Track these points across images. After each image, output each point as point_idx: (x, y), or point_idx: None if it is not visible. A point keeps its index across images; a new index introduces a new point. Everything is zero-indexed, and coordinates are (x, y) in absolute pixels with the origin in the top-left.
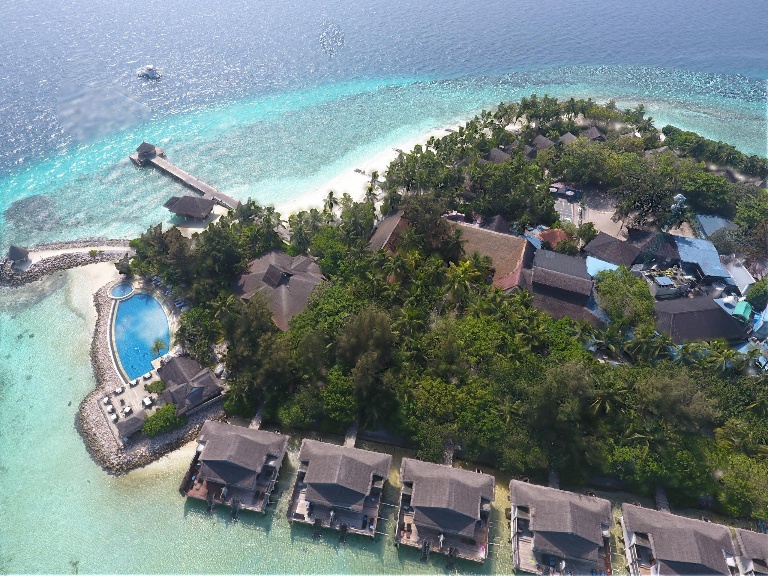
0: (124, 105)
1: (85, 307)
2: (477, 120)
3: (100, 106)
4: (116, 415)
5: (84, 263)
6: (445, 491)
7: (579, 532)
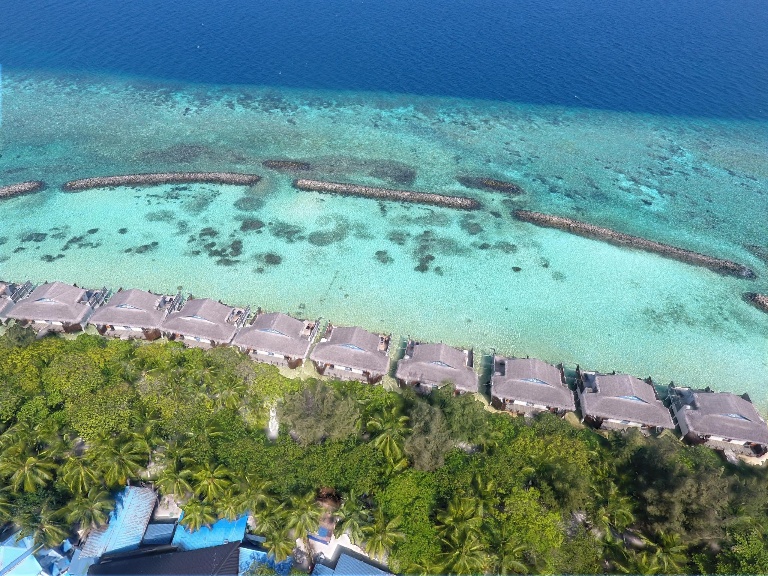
0: None
1: None
2: None
3: None
4: None
5: None
6: (539, 369)
7: (436, 345)
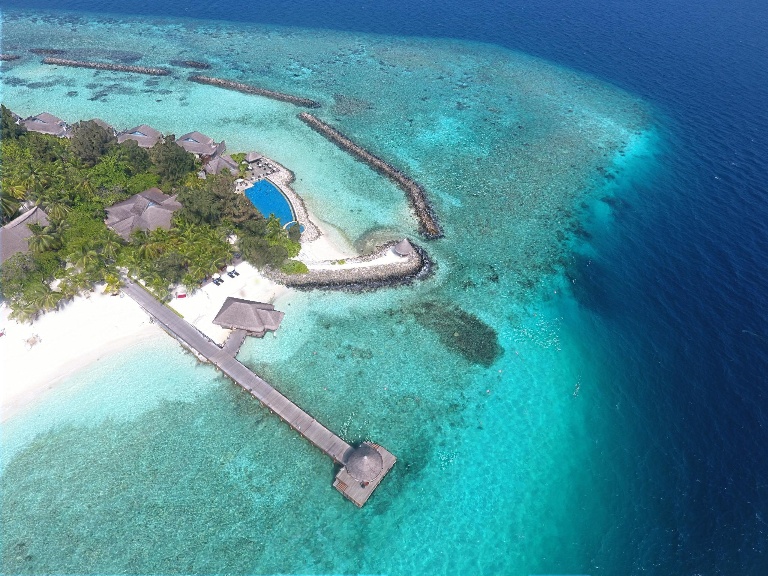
0: None
1: (324, 226)
2: None
3: None
4: (266, 163)
5: (347, 259)
6: None
7: None
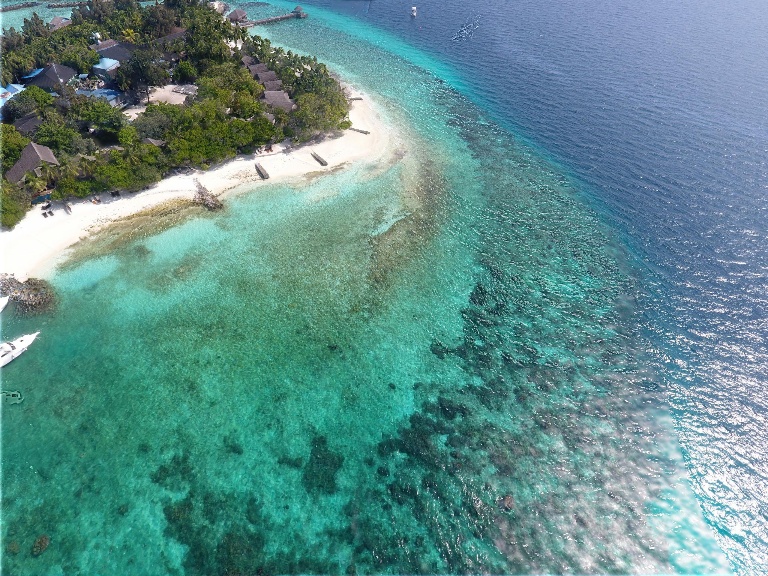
0: (361, 8)
1: None
2: None
3: (354, 2)
4: None
5: None
6: None
7: None
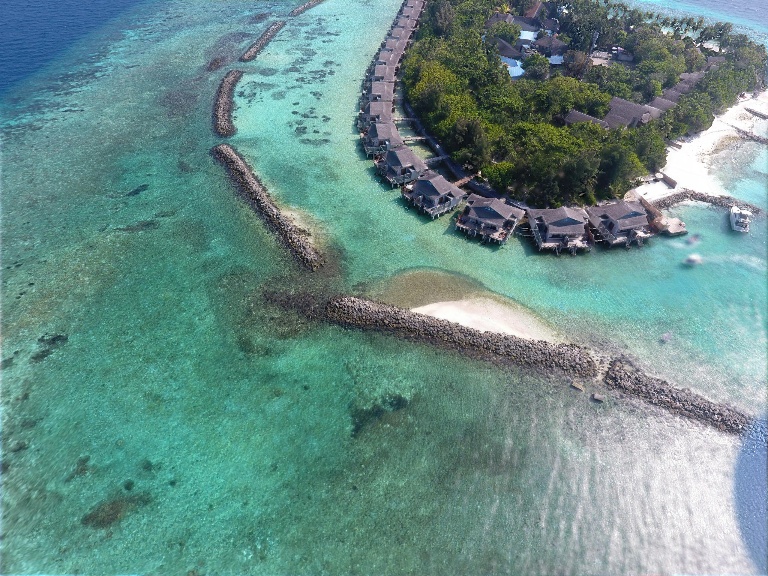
0: None
1: None
2: (673, 20)
3: None
4: None
5: None
6: None
7: (400, 19)
